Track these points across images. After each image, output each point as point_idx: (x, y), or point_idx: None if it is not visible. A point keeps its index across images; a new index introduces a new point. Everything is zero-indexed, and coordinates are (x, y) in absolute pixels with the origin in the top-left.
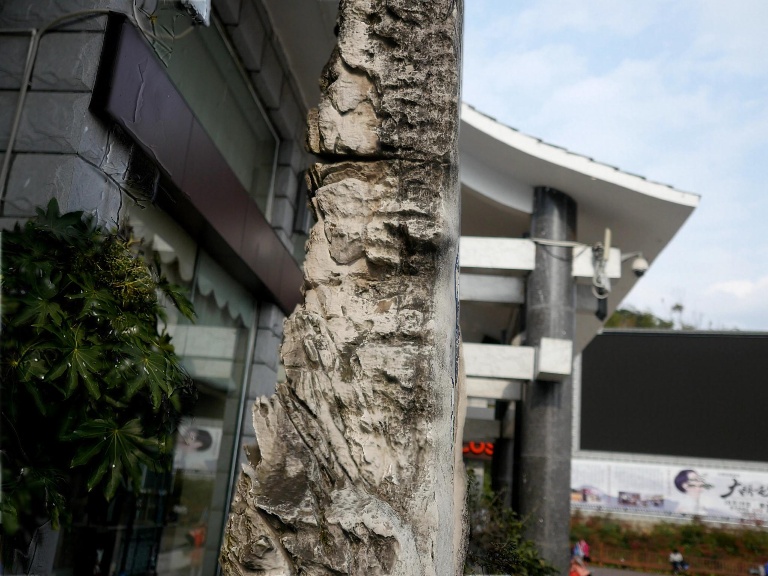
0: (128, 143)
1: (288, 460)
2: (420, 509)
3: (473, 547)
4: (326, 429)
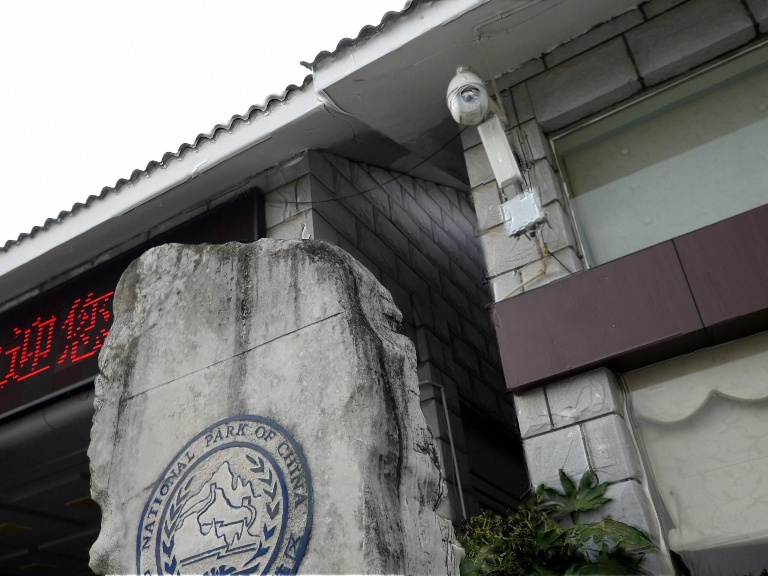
0: (535, 396)
1: None
2: None
3: None
4: None
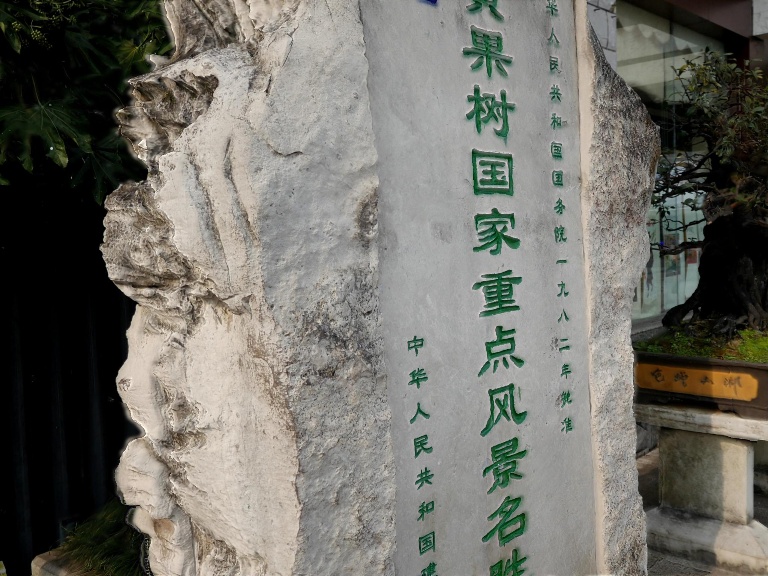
0: None
1: (188, 40)
2: (265, 47)
3: (762, 173)
4: (231, 1)
